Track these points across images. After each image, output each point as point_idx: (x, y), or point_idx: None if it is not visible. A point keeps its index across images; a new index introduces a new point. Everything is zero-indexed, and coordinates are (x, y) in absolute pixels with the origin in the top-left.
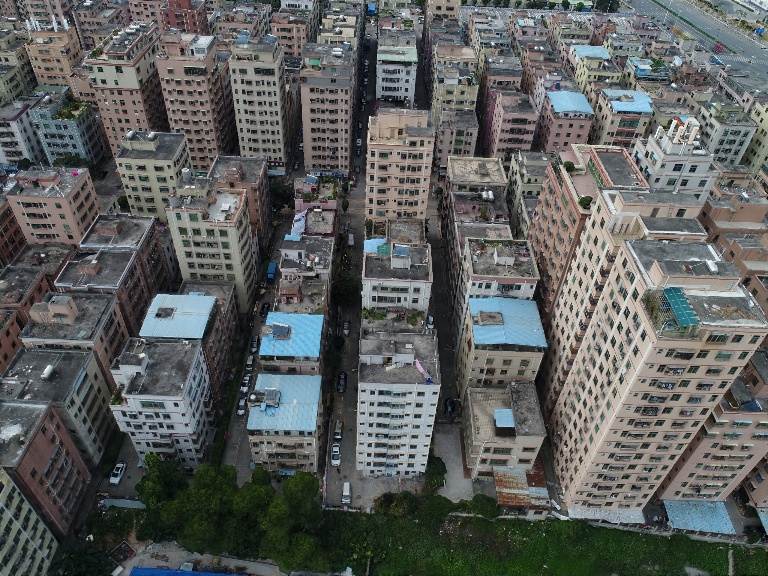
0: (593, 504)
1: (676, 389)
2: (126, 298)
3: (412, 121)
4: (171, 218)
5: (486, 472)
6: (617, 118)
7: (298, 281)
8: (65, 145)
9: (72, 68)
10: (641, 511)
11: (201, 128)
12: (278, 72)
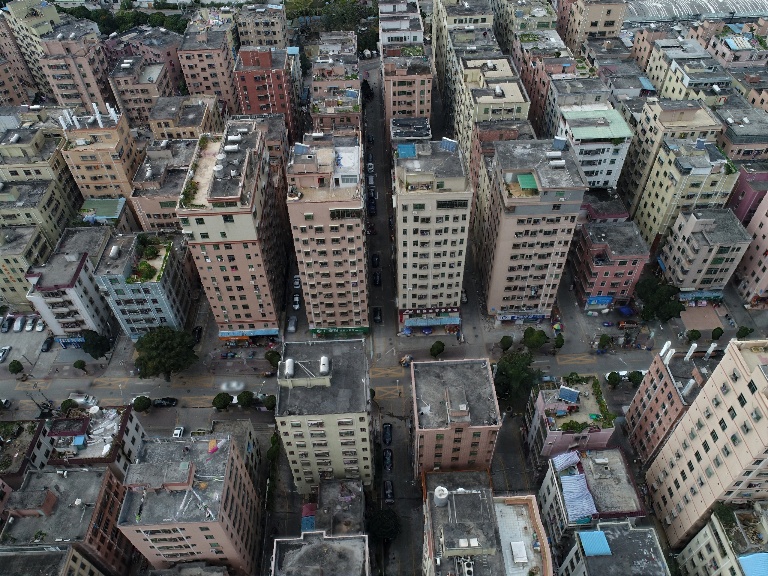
0: None
1: None
2: None
3: None
4: None
5: None
6: None
7: None
8: (146, 310)
9: (133, 182)
10: None
11: (346, 280)
12: None
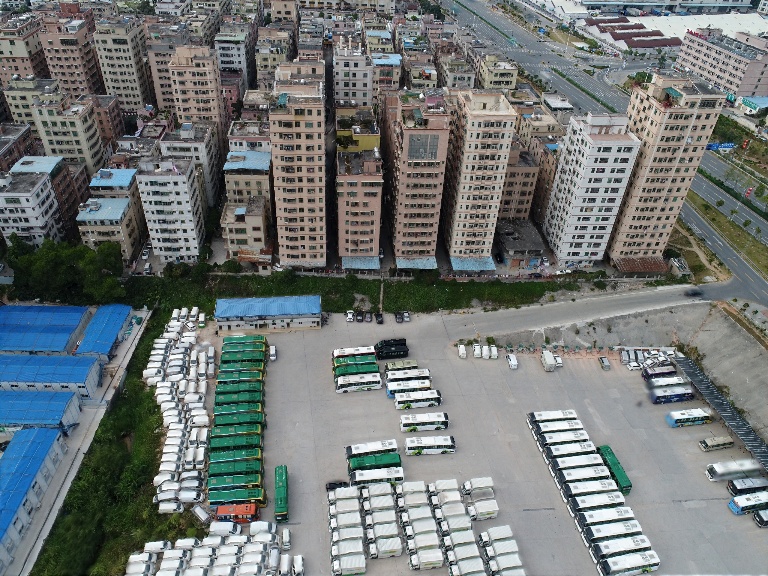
0: (294, 256)
1: (296, 152)
2: (6, 167)
3: (198, 52)
4: (36, 114)
5: (237, 252)
6: (377, 70)
7: (124, 154)
8: None
9: None
10: (325, 261)
11: (78, 86)
12: (131, 42)
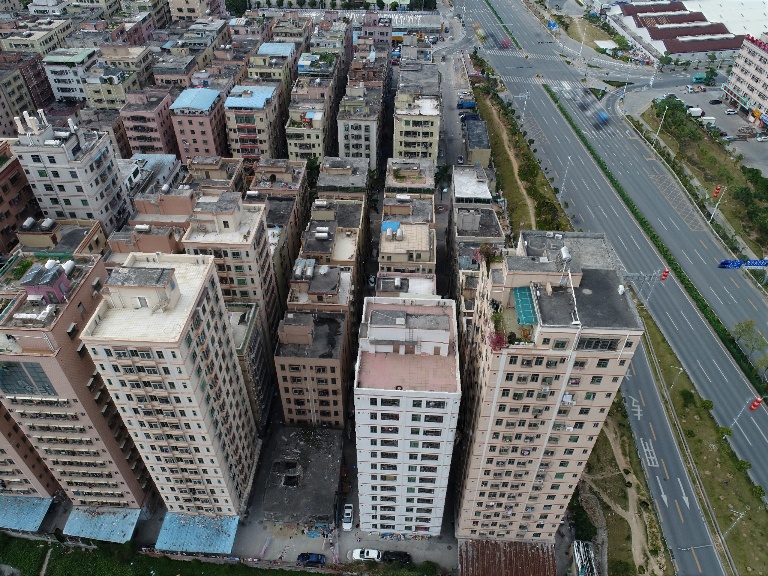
0: None
1: None
2: None
3: None
4: None
5: None
6: (231, 114)
7: None
8: None
9: None
10: None
11: None
12: None
